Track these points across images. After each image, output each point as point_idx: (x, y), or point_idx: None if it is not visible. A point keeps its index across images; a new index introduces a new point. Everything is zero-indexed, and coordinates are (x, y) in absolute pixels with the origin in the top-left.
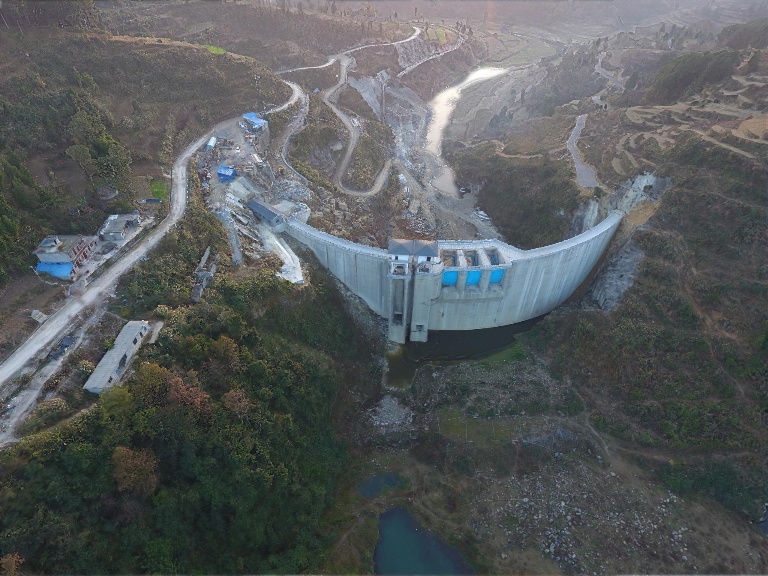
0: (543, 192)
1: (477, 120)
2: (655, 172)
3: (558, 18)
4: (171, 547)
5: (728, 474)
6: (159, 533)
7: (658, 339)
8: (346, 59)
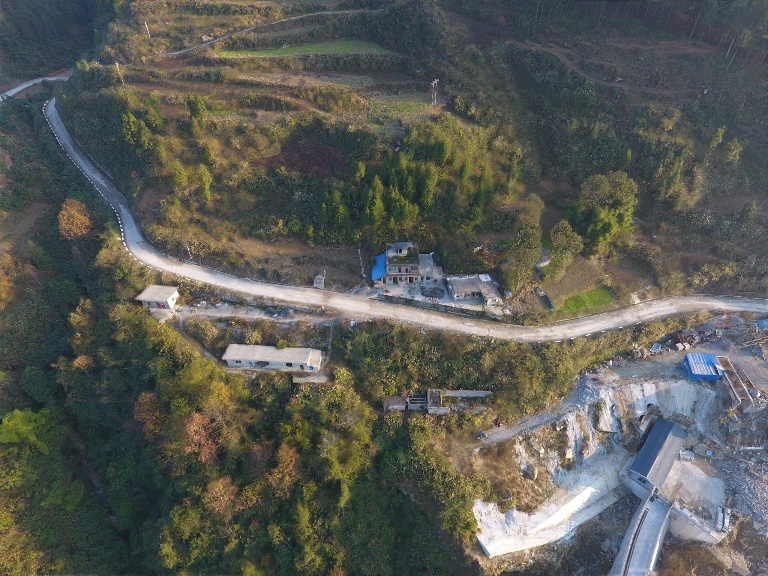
0: None
1: None
2: None
3: None
4: (131, 476)
5: None
6: (138, 460)
7: None
8: None
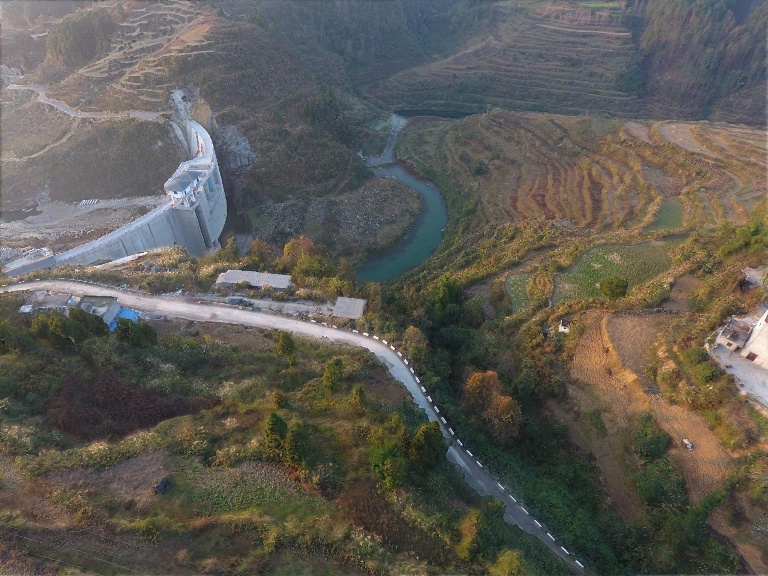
0: (127, 144)
1: None
2: (178, 87)
3: None
4: None
5: (357, 168)
6: None
7: (289, 149)
8: None
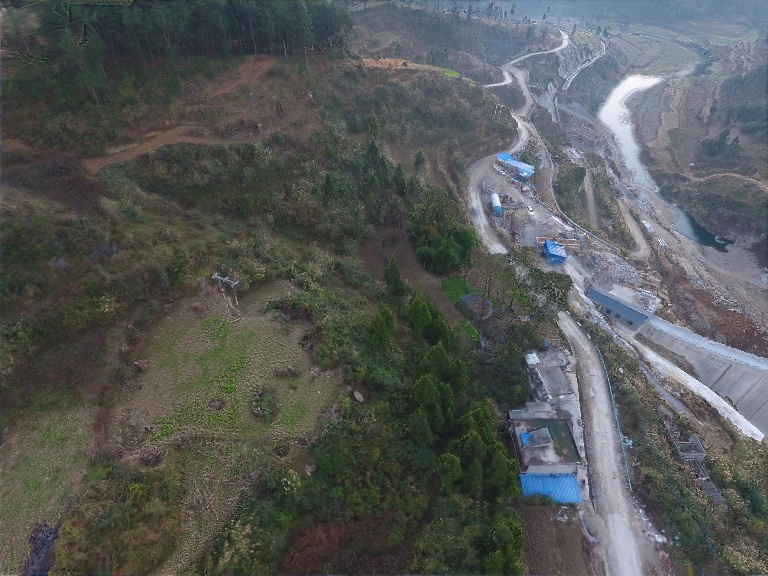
0: None
1: (677, 144)
2: None
3: (683, 16)
4: None
5: None
6: None
7: None
8: (518, 71)
